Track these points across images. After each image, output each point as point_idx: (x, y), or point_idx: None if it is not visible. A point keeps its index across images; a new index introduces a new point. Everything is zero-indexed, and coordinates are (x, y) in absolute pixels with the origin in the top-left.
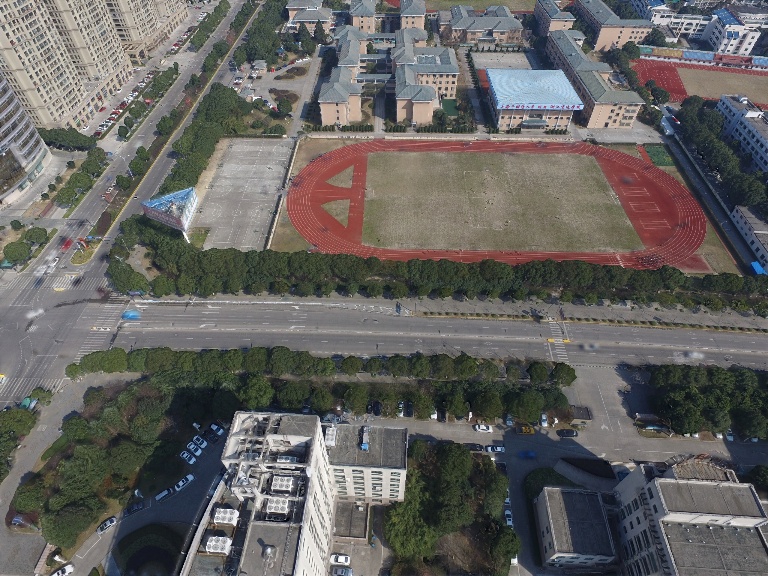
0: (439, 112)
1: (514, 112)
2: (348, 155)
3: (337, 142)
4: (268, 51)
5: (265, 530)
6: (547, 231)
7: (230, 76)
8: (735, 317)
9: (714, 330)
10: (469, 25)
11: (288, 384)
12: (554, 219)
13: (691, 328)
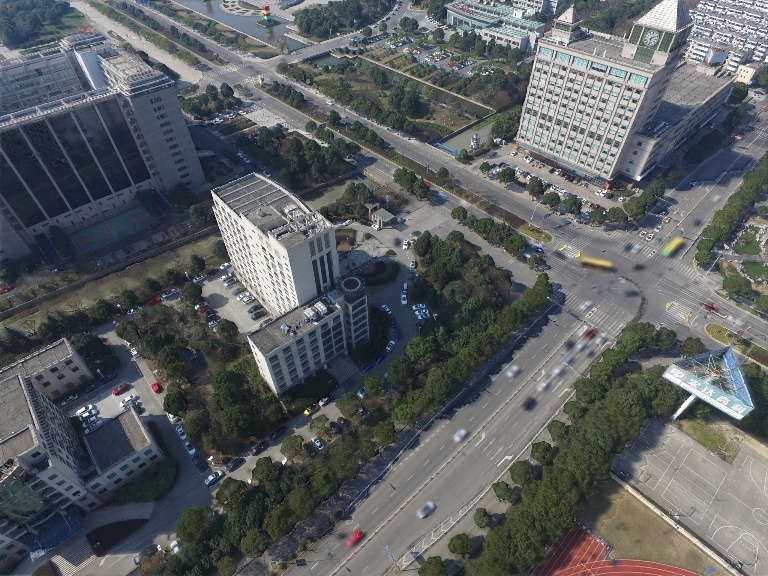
0: None
1: None
2: None
3: None
4: None
5: (272, 218)
6: None
7: None
8: None
9: None
10: None
11: (404, 365)
12: None
13: None
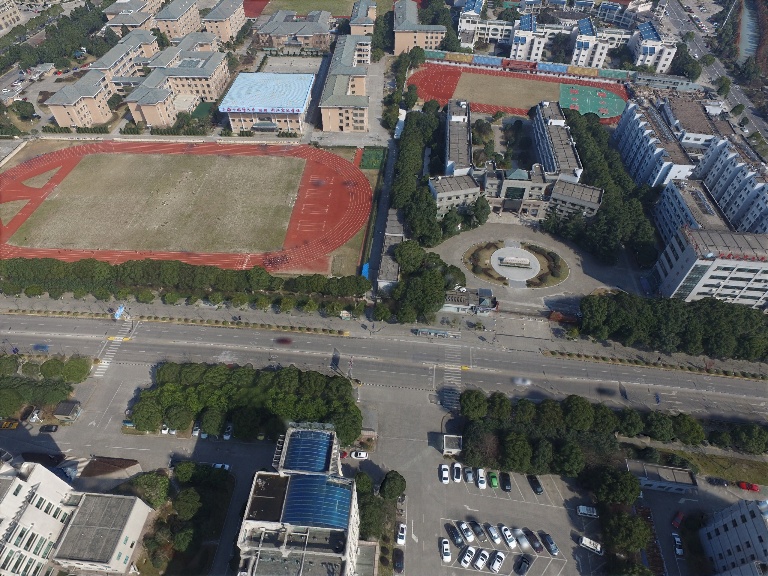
0: (180, 115)
1: (241, 115)
2: (65, 156)
3: (64, 143)
4: (67, 54)
5: None
6: (198, 232)
7: (15, 78)
8: (313, 318)
9: (281, 330)
10: (274, 30)
11: None
12: (215, 220)
13: (260, 328)
